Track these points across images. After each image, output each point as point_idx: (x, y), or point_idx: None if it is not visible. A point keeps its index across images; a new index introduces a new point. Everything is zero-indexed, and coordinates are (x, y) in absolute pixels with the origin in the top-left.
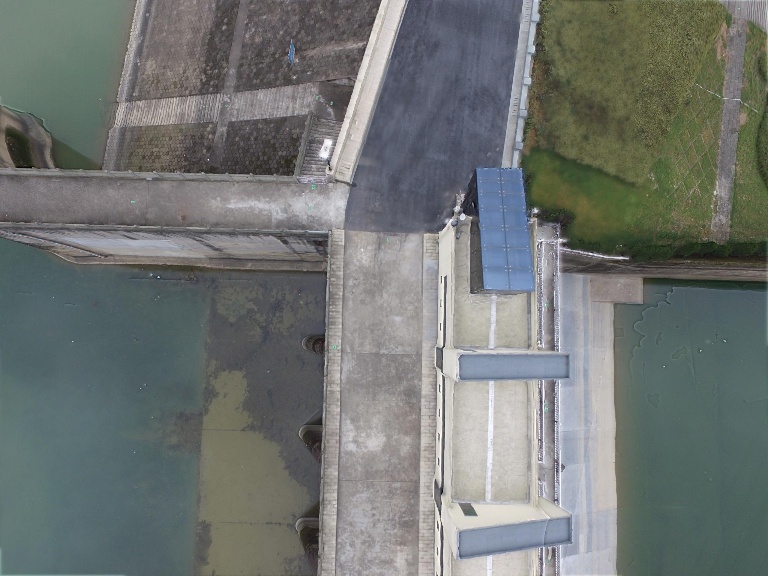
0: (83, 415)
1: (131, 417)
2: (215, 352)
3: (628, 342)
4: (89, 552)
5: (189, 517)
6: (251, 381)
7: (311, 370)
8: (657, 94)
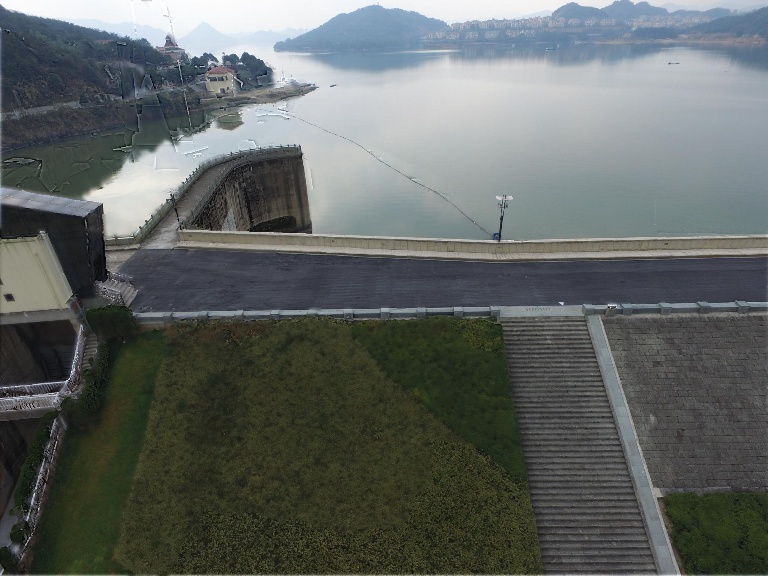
0: None
1: None
2: None
3: None
4: None
5: None
6: None
7: None
8: (281, 575)
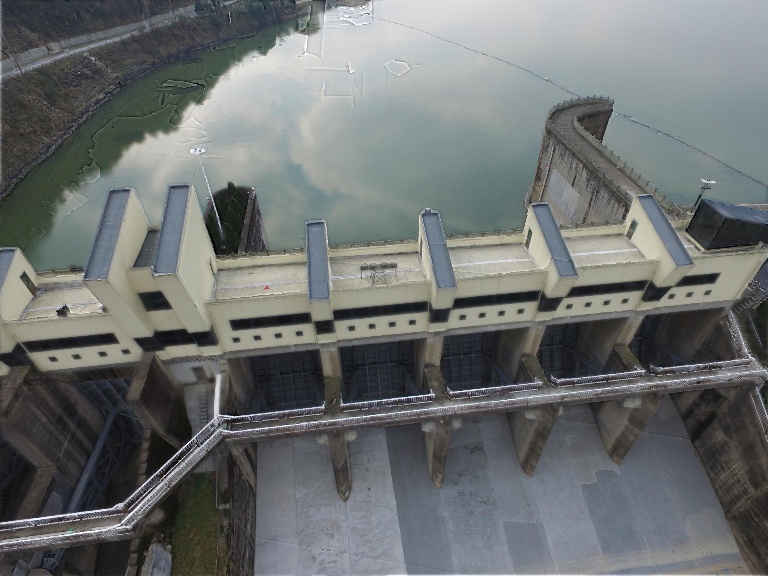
0: None
1: None
2: None
3: None
4: (365, 230)
5: None
6: None
7: None
8: None
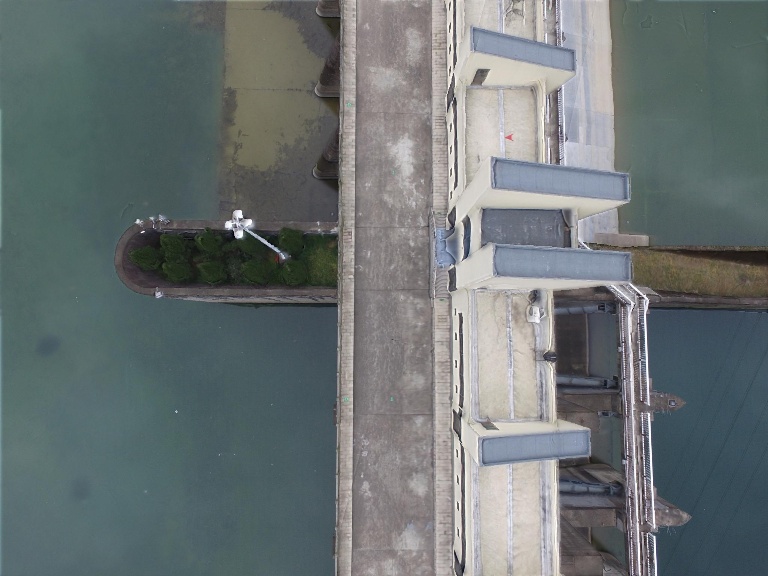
0: (115, 1)
1: (159, 2)
2: None
3: None
4: (124, 115)
5: (216, 87)
6: None
7: None
8: None
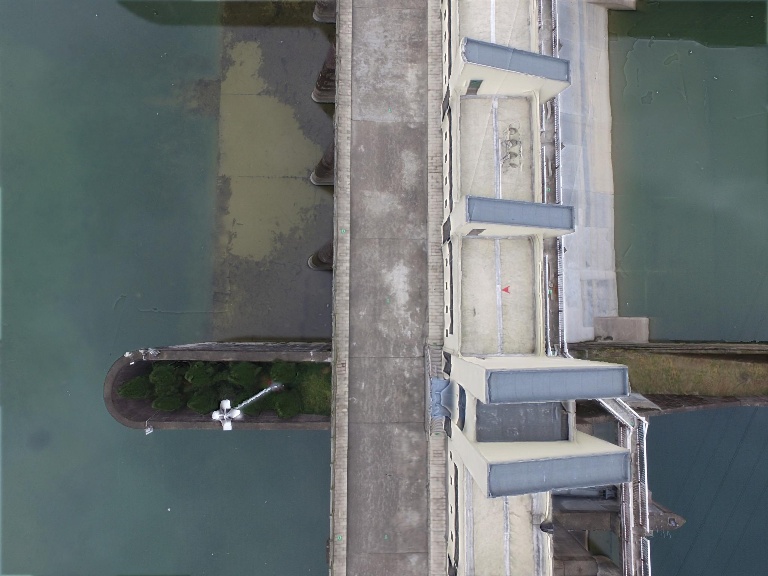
0: (108, 86)
1: (153, 86)
2: (231, 24)
3: (622, 47)
4: (117, 204)
5: (210, 174)
6: (265, 50)
7: (322, 40)
8: None
